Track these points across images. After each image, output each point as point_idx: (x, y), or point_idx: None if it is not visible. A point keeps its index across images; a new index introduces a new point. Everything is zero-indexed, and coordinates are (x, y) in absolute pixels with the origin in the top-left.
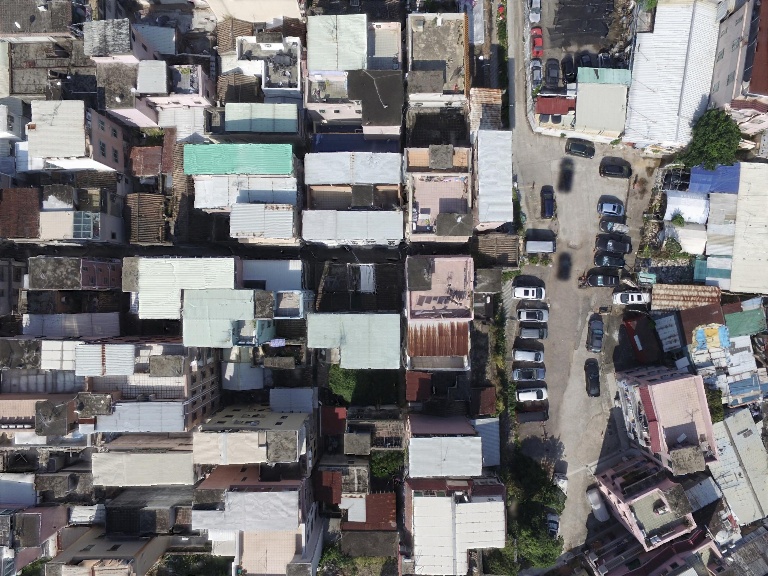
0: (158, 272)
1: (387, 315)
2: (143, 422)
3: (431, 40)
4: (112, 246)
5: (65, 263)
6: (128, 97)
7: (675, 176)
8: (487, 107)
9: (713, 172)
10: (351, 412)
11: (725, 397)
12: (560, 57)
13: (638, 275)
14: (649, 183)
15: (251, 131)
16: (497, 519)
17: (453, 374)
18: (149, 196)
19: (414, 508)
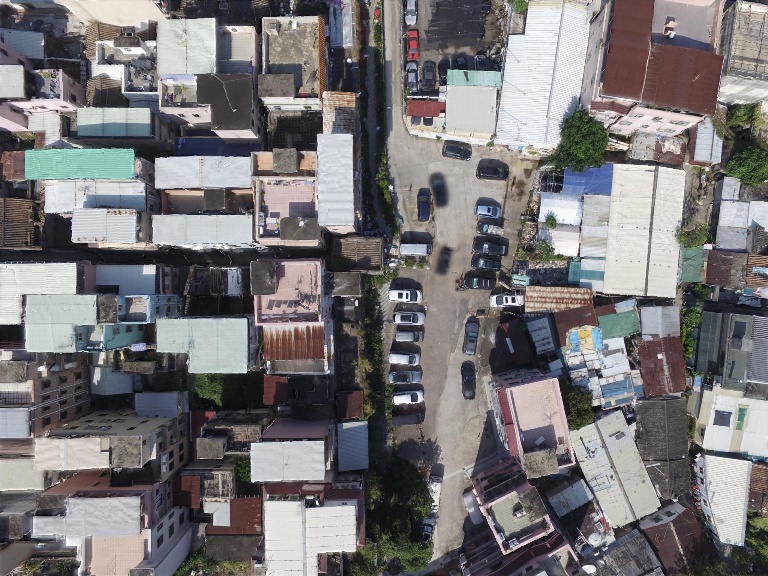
0: (4, 277)
1: (234, 319)
2: None
3: (287, 43)
4: None
5: None
6: None
7: (551, 178)
8: (340, 110)
9: (586, 174)
10: (217, 416)
11: (597, 399)
12: (437, 59)
13: (512, 277)
14: (527, 185)
15: (103, 135)
16: (348, 523)
17: (315, 378)
18: (16, 201)
19: (265, 513)
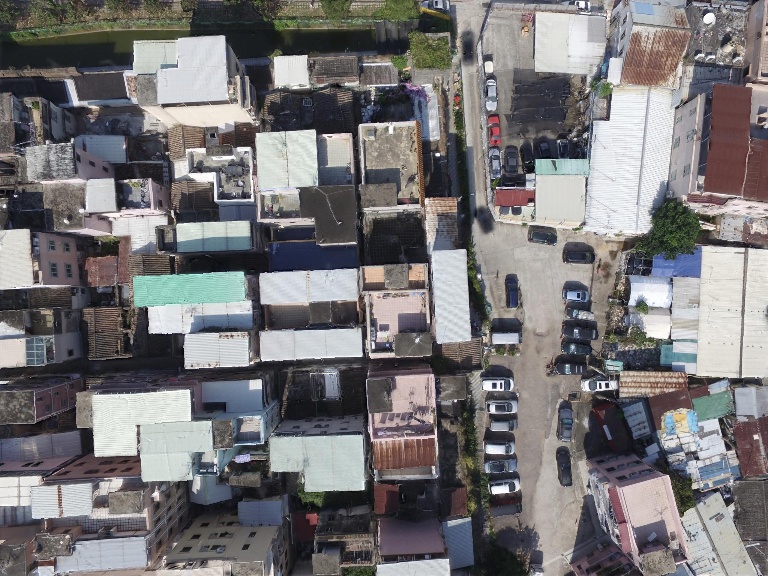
0: (113, 404)
1: (349, 436)
2: (105, 559)
3: (384, 148)
4: (70, 360)
5: (18, 396)
6: (77, 218)
7: (638, 260)
8: (443, 216)
9: None
10: (321, 522)
11: (696, 482)
12: (519, 144)
13: (605, 363)
14: (613, 267)
15: (204, 251)
16: None
17: (422, 481)
18: (105, 310)
19: None
